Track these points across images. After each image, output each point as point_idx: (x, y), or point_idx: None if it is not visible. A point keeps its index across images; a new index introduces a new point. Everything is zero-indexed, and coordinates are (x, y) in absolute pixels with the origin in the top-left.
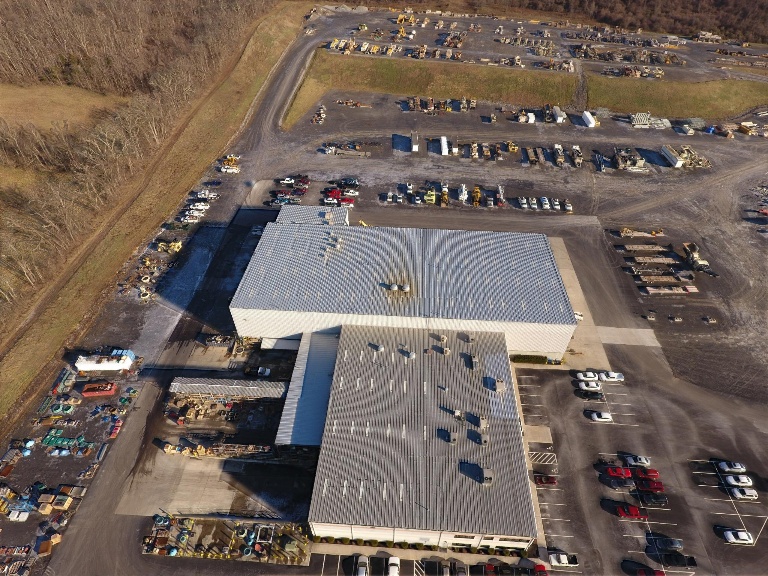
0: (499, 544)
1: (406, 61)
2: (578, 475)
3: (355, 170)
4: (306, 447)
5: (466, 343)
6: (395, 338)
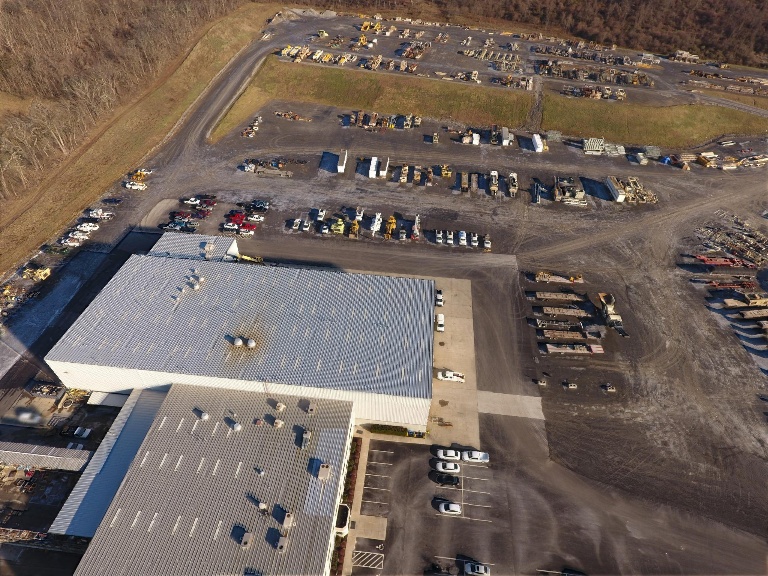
0: None
1: (357, 72)
2: None
3: (270, 191)
4: (84, 538)
5: (305, 413)
6: (226, 403)
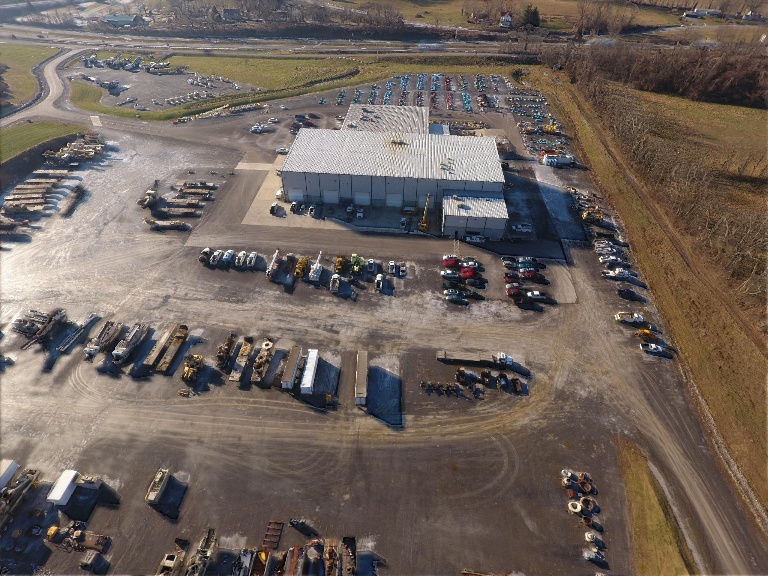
0: None
1: None
2: None
3: (454, 321)
4: None
5: None
6: None
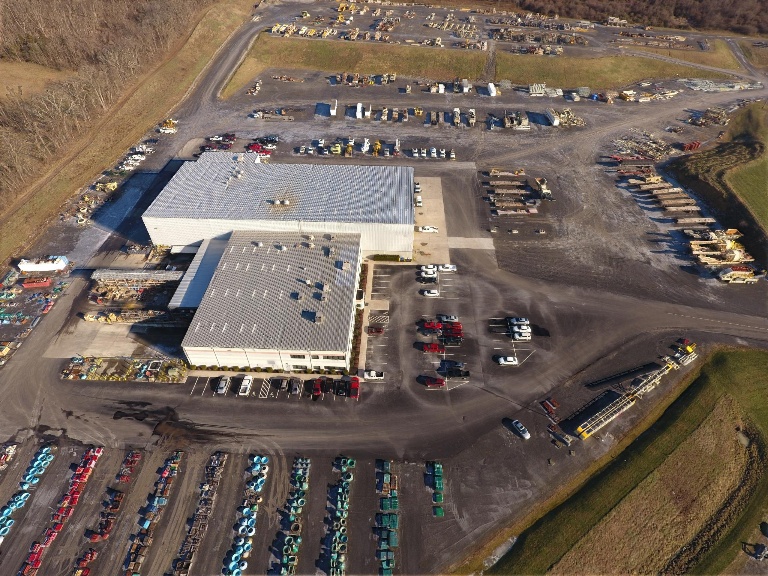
0: (325, 364)
1: (338, 42)
2: (402, 328)
3: (278, 130)
4: (192, 309)
5: (329, 240)
6: (273, 238)
